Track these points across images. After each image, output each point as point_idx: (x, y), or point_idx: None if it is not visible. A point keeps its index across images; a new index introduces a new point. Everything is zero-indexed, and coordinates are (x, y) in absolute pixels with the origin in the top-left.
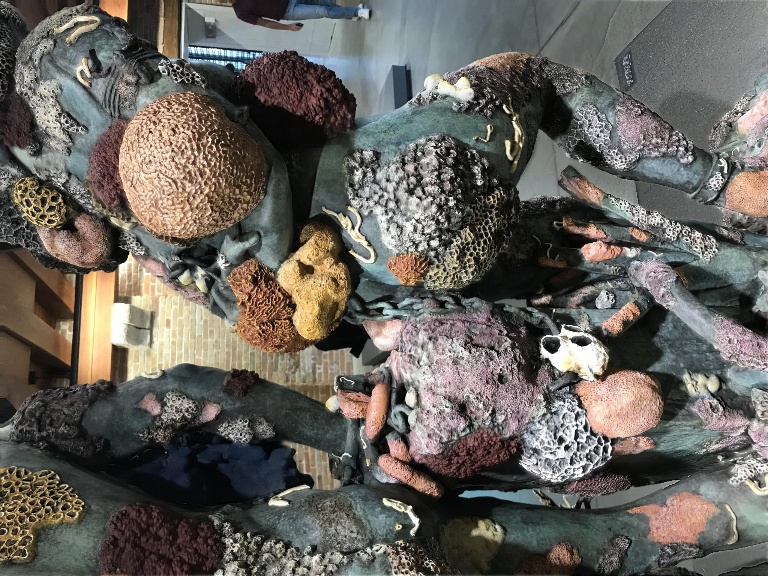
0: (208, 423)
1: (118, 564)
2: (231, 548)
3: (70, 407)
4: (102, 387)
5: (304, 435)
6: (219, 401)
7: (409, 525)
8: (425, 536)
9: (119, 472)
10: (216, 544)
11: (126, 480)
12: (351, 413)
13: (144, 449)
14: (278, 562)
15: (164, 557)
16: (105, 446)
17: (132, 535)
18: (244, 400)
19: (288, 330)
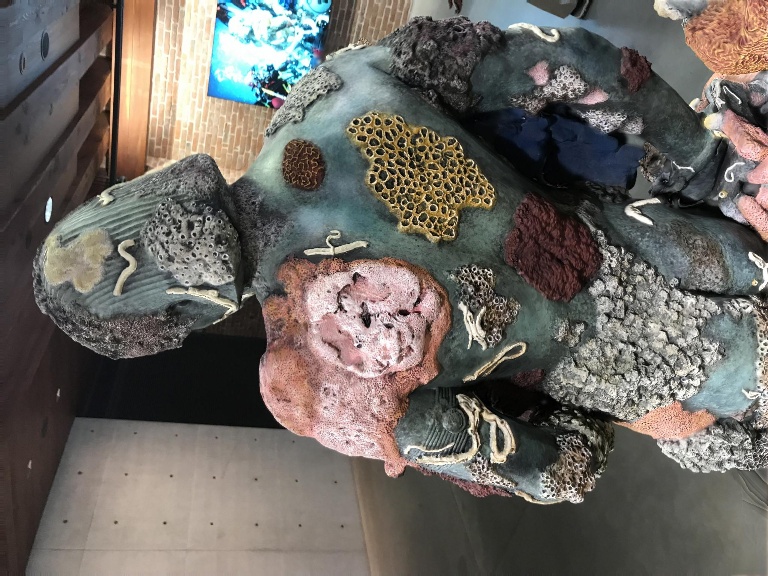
0: (581, 104)
1: (520, 256)
2: (609, 262)
3: (464, 57)
4: (494, 37)
5: (664, 141)
6: (610, 90)
7: (761, 281)
8: (764, 290)
9: (486, 134)
10: (596, 254)
11: (495, 147)
12: (750, 155)
13: (505, 109)
14: (647, 286)
15: (554, 256)
16: (478, 102)
17: (535, 233)
18: (635, 96)
19: (766, 65)
